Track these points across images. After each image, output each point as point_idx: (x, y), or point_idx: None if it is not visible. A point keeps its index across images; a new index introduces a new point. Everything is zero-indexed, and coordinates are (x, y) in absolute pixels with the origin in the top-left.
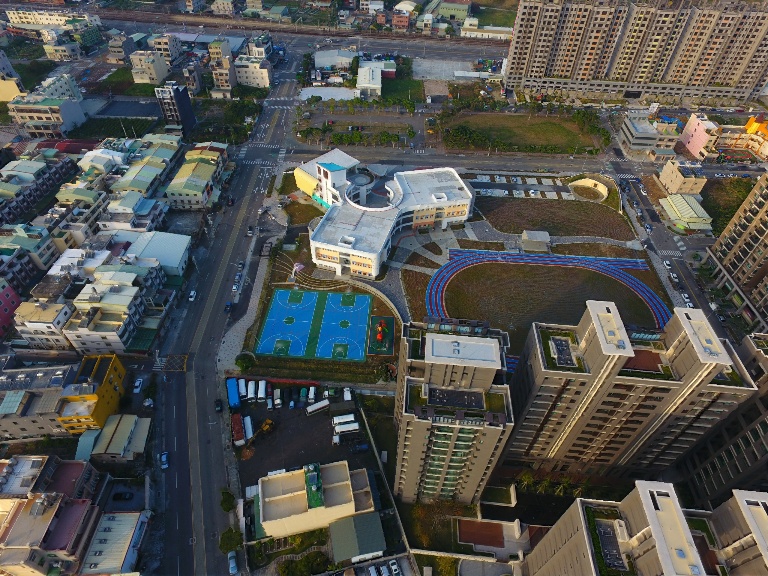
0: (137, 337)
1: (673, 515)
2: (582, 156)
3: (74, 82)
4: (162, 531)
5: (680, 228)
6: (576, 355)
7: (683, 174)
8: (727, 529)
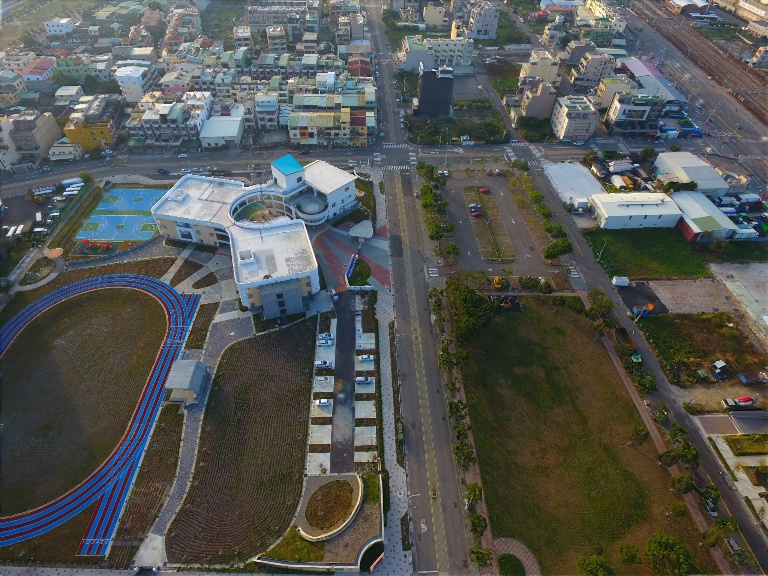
0: (140, 140)
1: None
2: (484, 534)
3: (471, 48)
4: (1, 178)
5: None
6: None
7: None
8: None
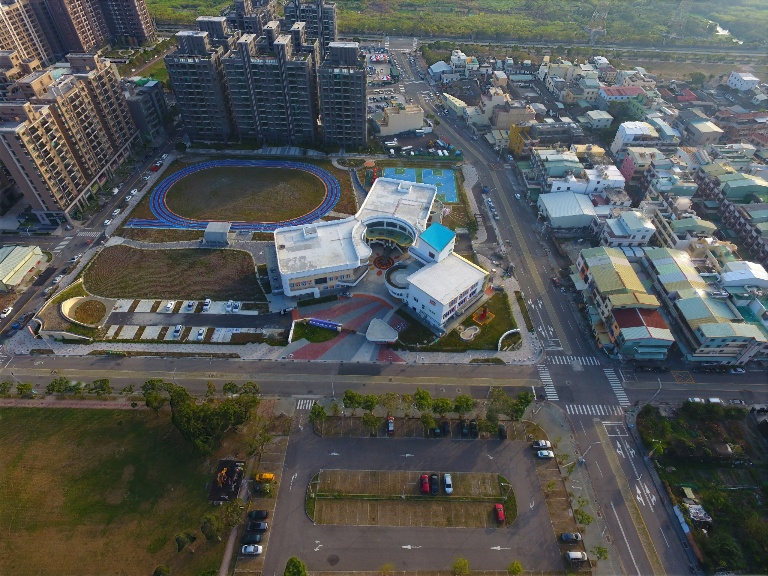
0: None
1: None
2: (3, 401)
3: None
4: None
5: None
6: None
7: None
8: (275, 39)
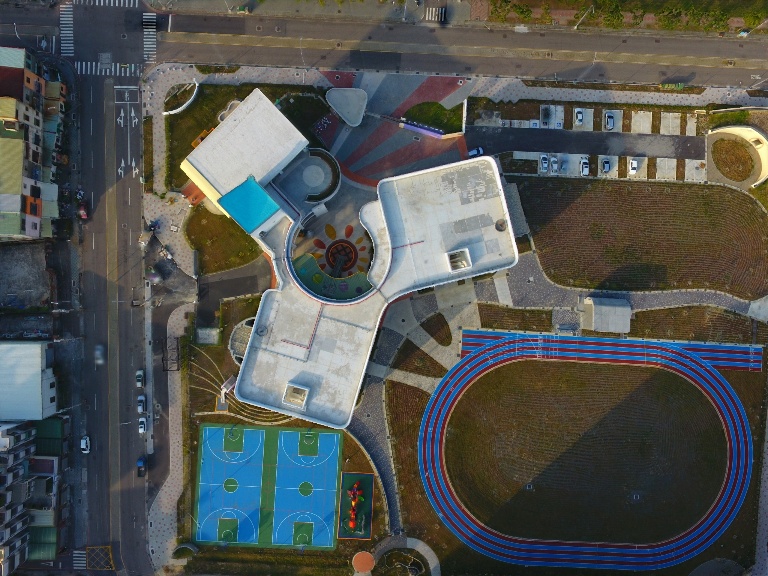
0: (34, 541)
1: None
2: (767, 25)
3: None
4: None
5: None
6: None
7: None
8: None
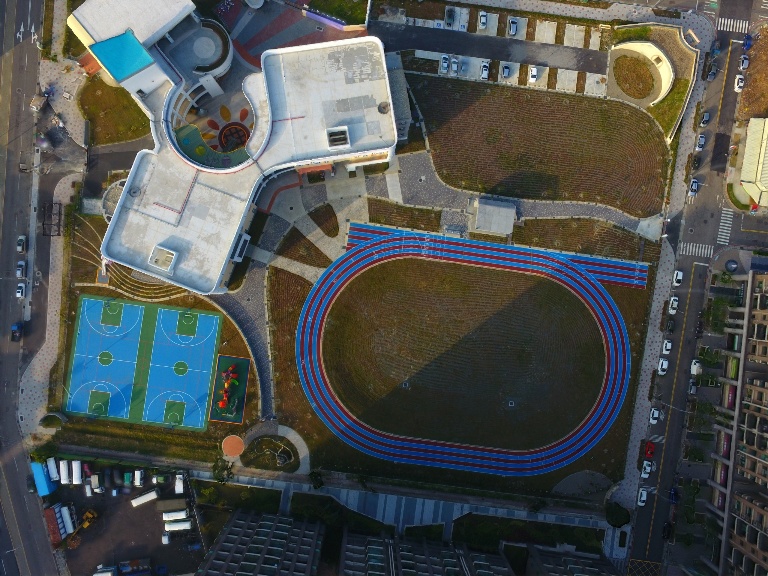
0: None
1: None
2: None
3: None
4: None
5: (746, 192)
6: None
7: None
8: None
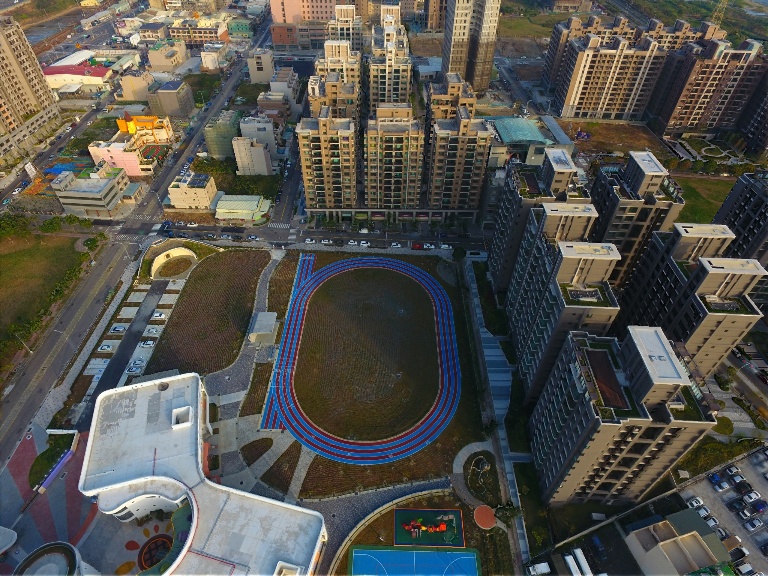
0: None
1: (721, 262)
2: (94, 253)
3: None
4: None
5: (259, 219)
6: (583, 288)
7: (201, 187)
8: (685, 252)
